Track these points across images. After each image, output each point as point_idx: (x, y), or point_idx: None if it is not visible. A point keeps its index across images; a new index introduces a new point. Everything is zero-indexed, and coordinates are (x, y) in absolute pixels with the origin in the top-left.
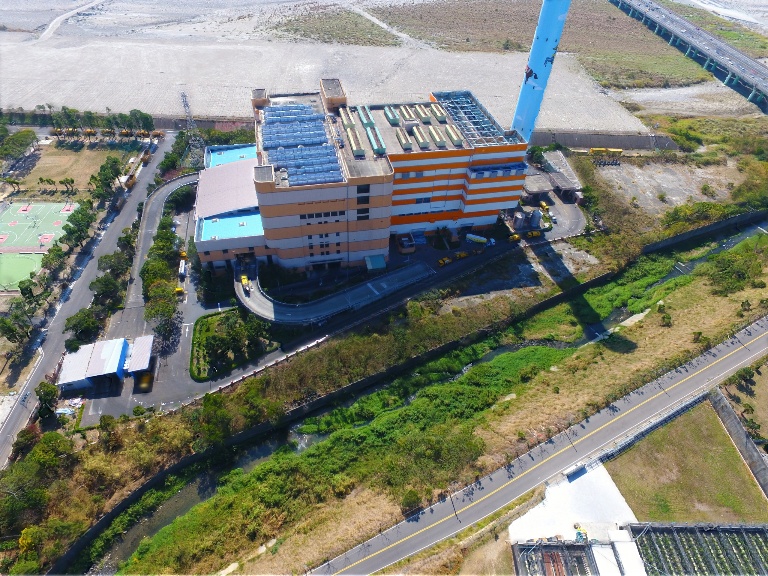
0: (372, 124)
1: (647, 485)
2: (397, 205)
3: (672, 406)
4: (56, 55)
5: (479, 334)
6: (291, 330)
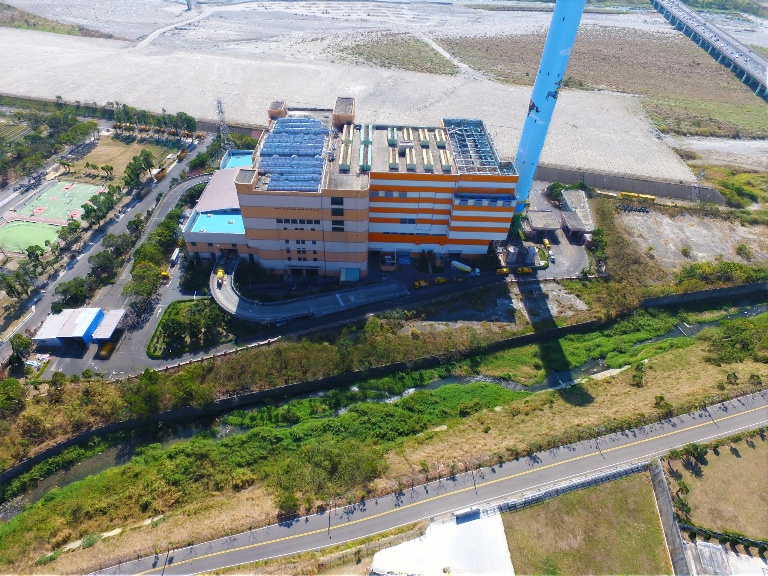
0: (369, 142)
1: (541, 546)
2: (381, 222)
3: (603, 469)
4: (144, 61)
5: (431, 360)
6: (250, 326)
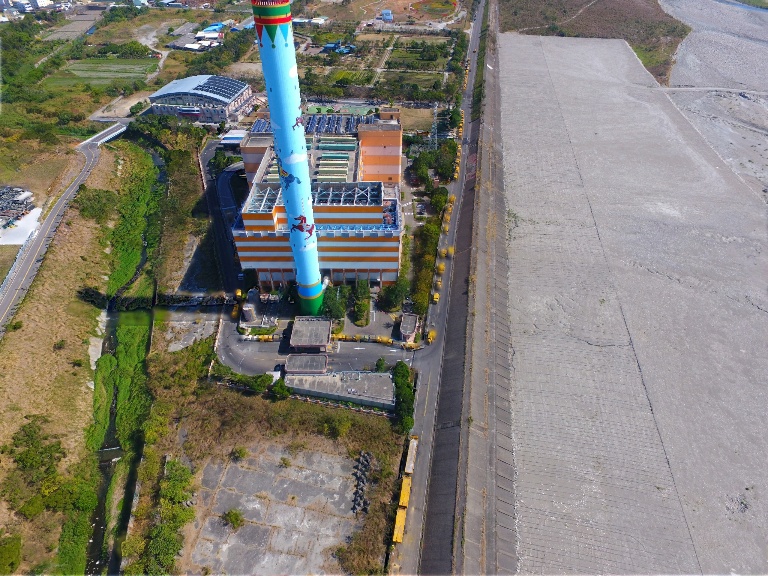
0: None
1: None
2: None
3: (8, 288)
4: (612, 96)
5: None
6: None
